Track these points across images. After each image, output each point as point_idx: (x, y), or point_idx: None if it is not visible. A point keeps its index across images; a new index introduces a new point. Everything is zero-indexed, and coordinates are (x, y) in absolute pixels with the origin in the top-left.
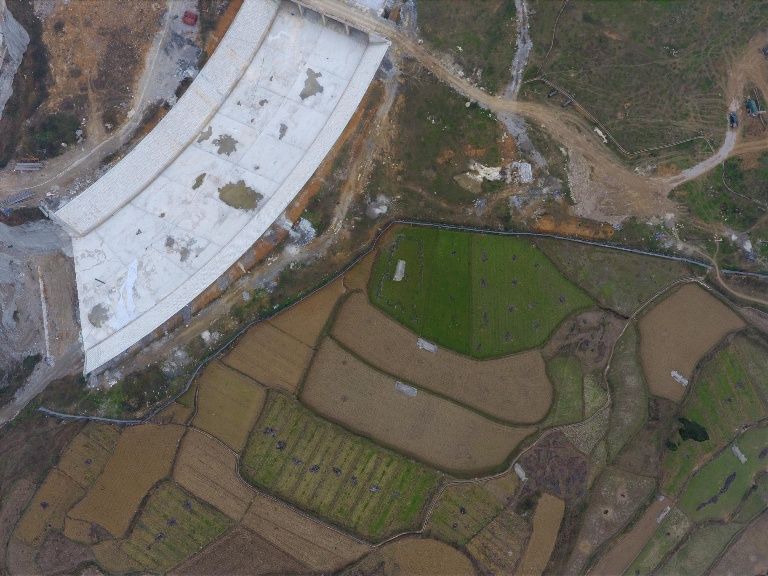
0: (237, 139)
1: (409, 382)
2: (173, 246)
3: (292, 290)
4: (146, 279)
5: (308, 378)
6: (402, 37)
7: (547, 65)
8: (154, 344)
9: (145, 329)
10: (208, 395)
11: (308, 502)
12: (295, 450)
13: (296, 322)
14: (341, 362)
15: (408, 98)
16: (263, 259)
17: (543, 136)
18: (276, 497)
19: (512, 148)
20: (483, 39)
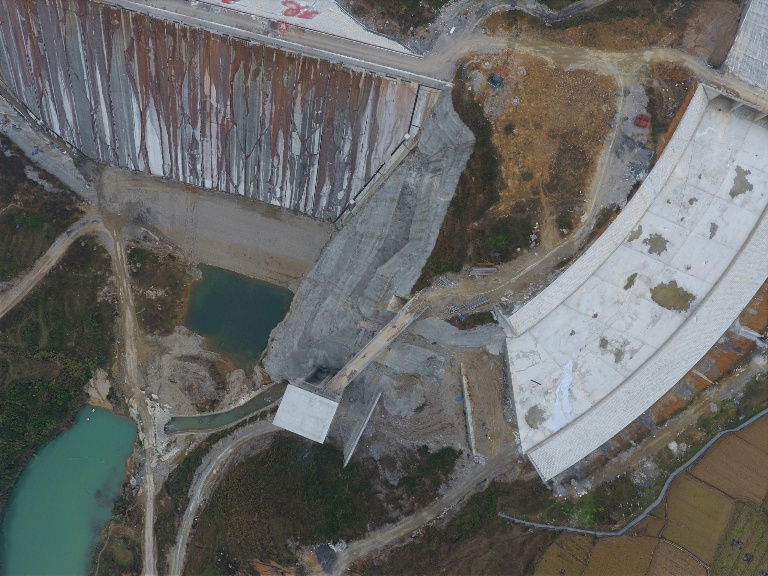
0: (668, 238)
1: None
2: (607, 347)
3: (756, 401)
4: (581, 380)
5: None
6: None
7: None
8: (622, 454)
9: (599, 436)
10: (677, 506)
11: None
12: (762, 563)
13: (761, 433)
14: None
15: None
16: (731, 370)
17: None
18: None
19: None
20: None
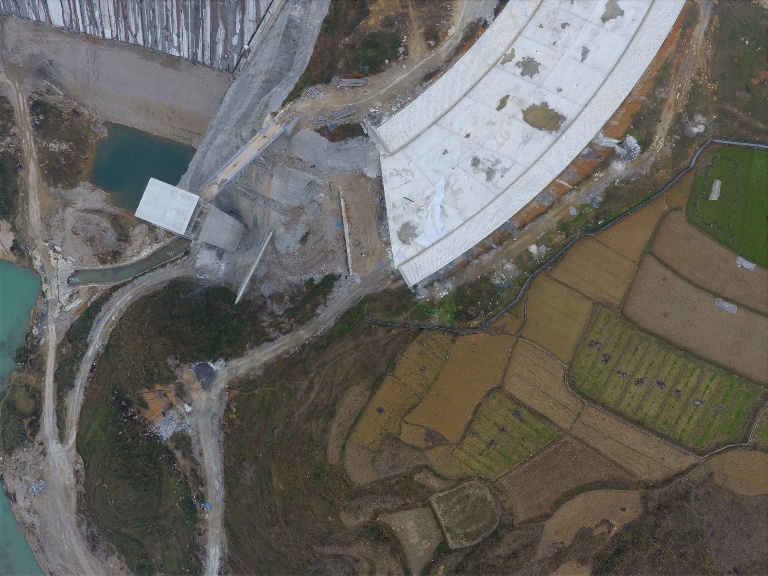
0: (540, 61)
1: (728, 299)
2: (479, 166)
3: (616, 206)
4: (453, 198)
5: (629, 293)
6: None
7: None
8: (483, 256)
9: (465, 244)
10: (536, 307)
11: (633, 414)
12: (620, 363)
13: (620, 237)
14: (661, 278)
15: (722, 19)
16: (590, 174)
17: None
18: (604, 408)
19: None
20: None
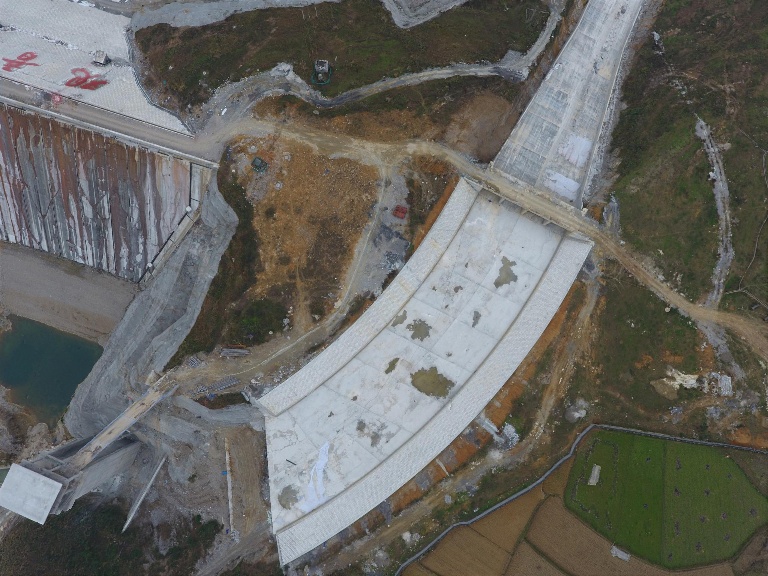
0: (431, 325)
1: None
2: (364, 430)
3: (492, 494)
4: (336, 462)
5: None
6: (605, 238)
7: (750, 277)
8: (356, 543)
9: (341, 521)
10: None
11: None
12: None
13: (495, 526)
14: (536, 567)
15: (609, 300)
16: (467, 463)
17: (743, 348)
18: None
19: (711, 358)
20: (684, 243)
